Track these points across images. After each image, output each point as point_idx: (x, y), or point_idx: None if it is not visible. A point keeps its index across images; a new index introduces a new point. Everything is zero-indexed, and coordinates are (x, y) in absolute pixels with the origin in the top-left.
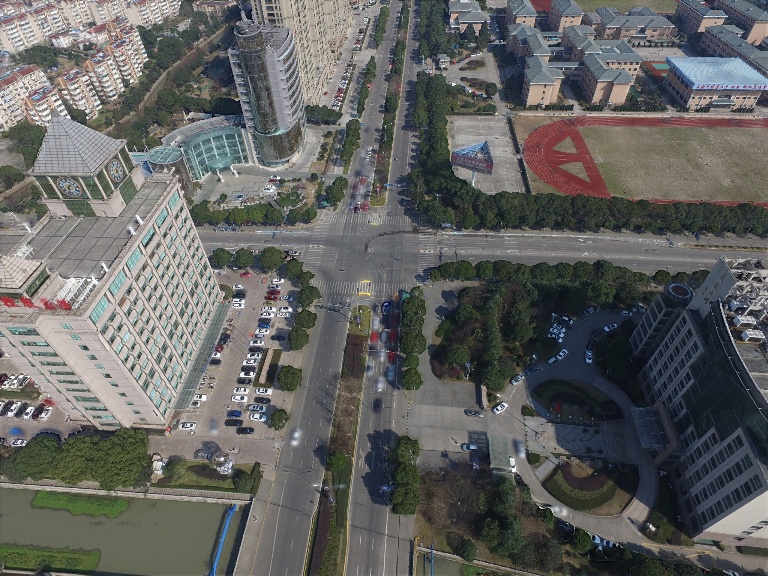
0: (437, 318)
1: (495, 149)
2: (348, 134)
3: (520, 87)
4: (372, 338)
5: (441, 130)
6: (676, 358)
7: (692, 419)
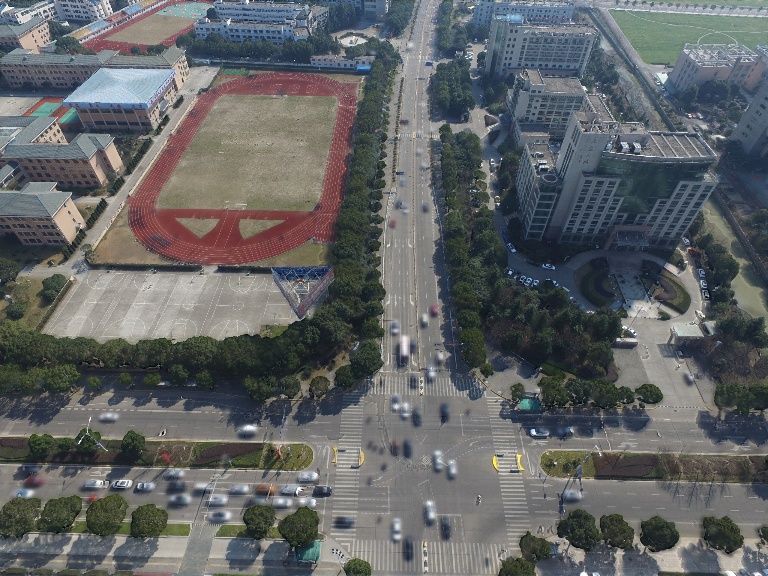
0: (537, 377)
1: (180, 292)
2: (62, 523)
3: (7, 239)
4: (592, 447)
5: (125, 345)
6: (596, 203)
7: (636, 212)
